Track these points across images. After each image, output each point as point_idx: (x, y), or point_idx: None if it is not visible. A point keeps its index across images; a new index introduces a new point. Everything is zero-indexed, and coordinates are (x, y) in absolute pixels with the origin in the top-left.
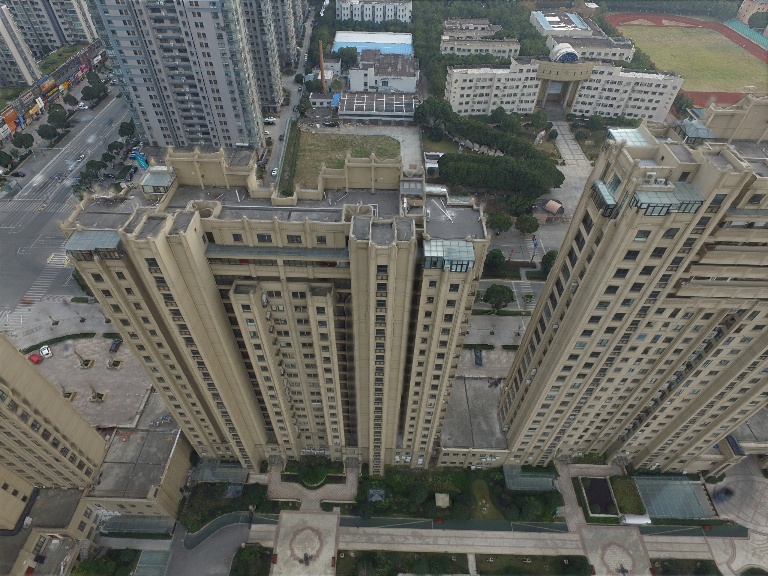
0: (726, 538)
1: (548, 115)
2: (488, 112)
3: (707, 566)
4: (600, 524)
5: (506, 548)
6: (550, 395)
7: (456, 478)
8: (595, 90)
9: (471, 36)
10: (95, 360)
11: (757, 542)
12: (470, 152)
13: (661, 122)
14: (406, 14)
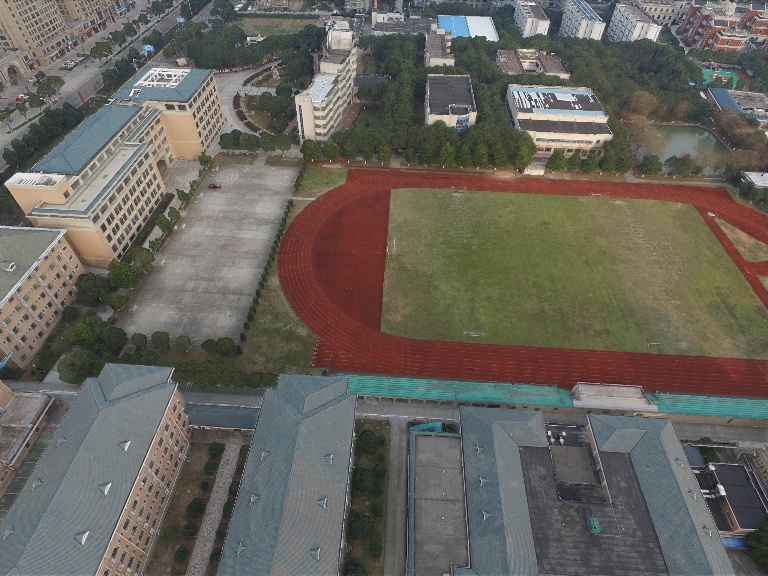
0: None
1: None
2: None
3: None
4: None
5: None
6: None
7: None
8: None
9: None
10: None
11: None
12: None
13: (301, 143)
14: (533, 30)
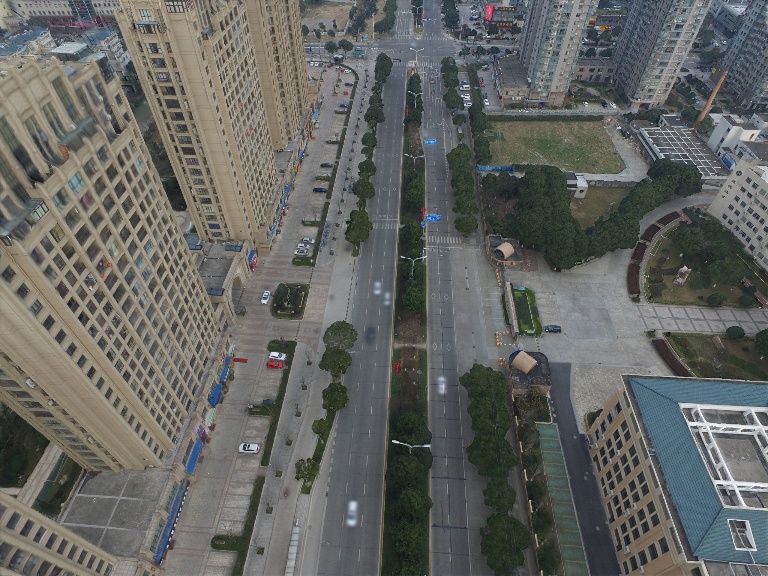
0: None
1: None
2: (747, 244)
3: None
4: None
5: None
6: None
7: None
8: None
9: None
10: (342, 82)
11: None
12: None
13: None
14: None
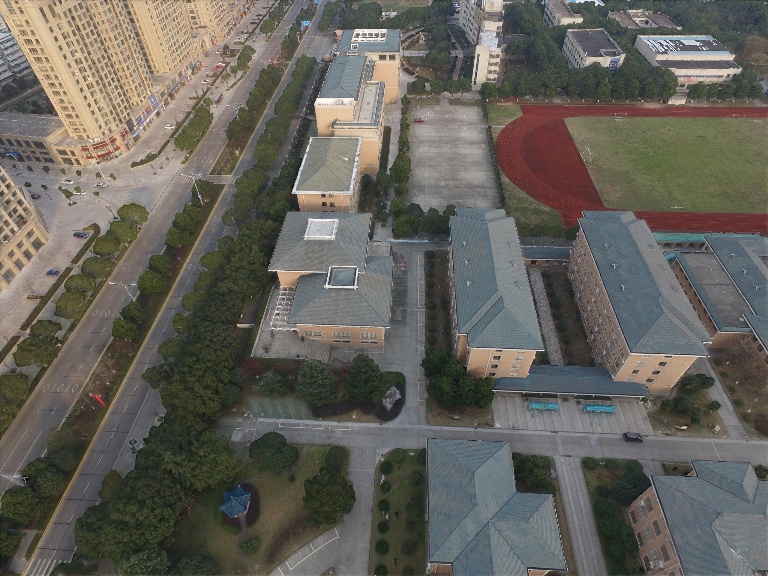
0: None
1: (469, 49)
2: None
3: None
4: None
5: None
6: None
7: None
8: None
9: None
10: None
11: None
12: None
13: None
14: None
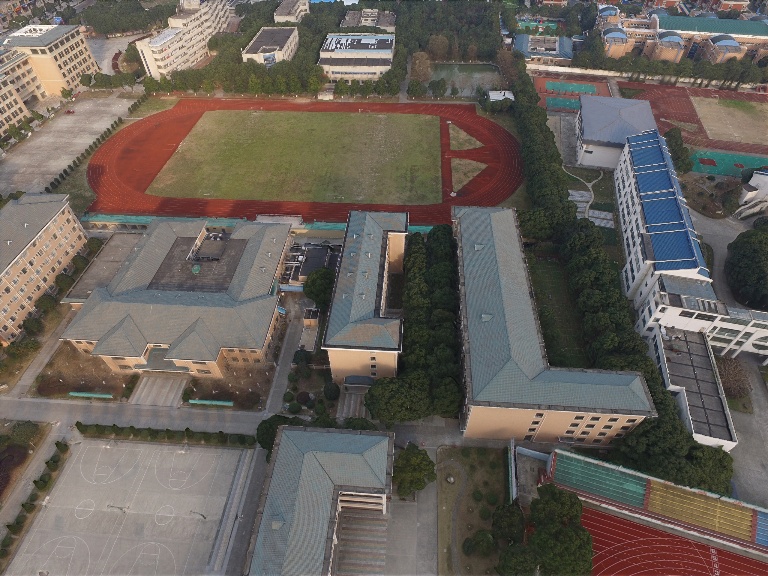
0: None
1: None
2: None
3: None
4: None
5: None
6: None
7: None
8: None
9: None
10: None
11: None
12: None
13: None
14: None
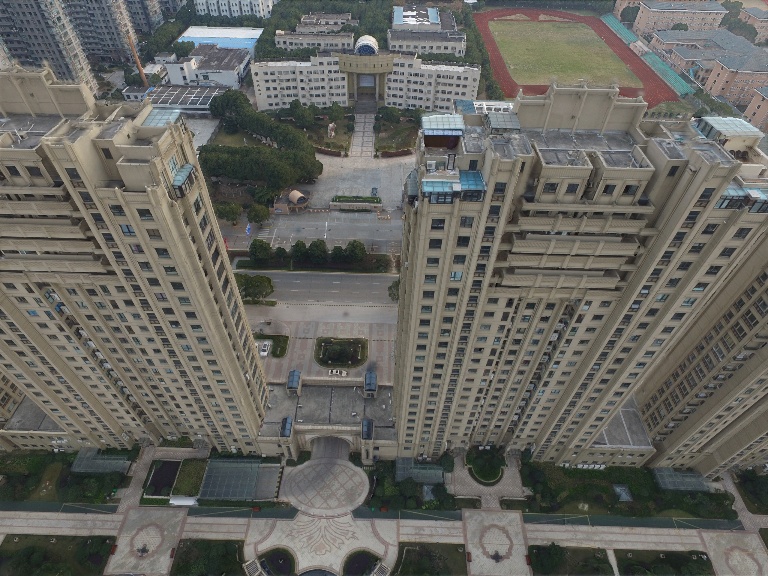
0: (270, 519)
1: (360, 108)
2: None
3: (213, 546)
4: (151, 505)
5: (42, 528)
6: (17, 374)
7: (33, 461)
8: (401, 83)
9: (324, 31)
10: None
11: (299, 523)
12: (259, 144)
13: None
14: (264, 9)
